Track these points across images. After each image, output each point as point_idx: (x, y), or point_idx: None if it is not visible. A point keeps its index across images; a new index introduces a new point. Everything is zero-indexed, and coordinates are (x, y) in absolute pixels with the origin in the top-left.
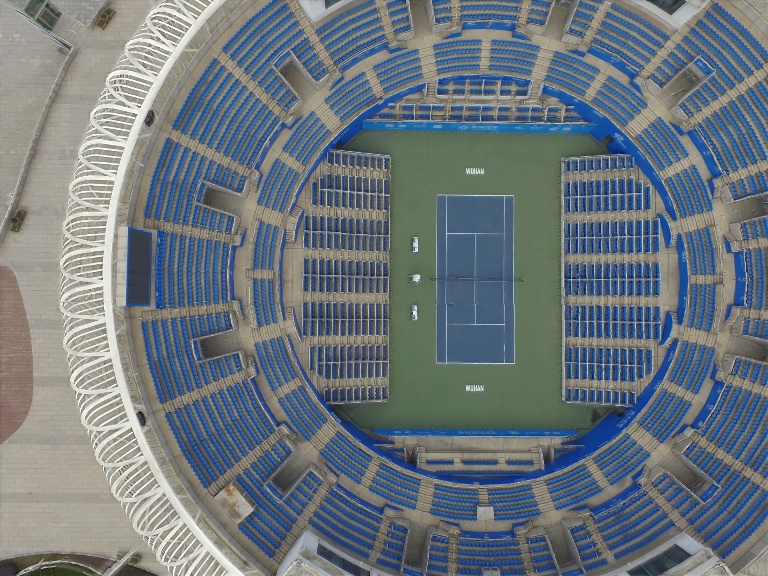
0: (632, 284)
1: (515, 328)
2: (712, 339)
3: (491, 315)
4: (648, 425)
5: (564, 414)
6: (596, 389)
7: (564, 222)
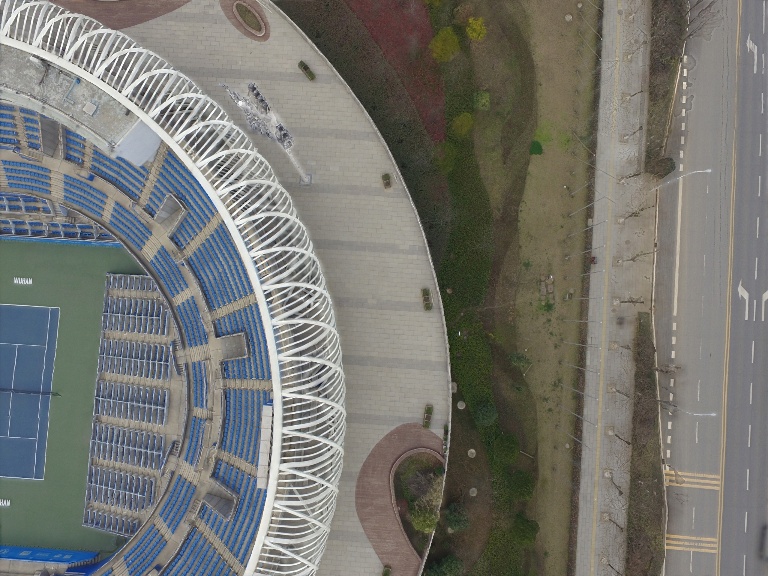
0: (145, 410)
1: (48, 443)
2: (197, 477)
3: (25, 428)
4: (129, 561)
5: (88, 535)
6: (109, 514)
7: (101, 338)
